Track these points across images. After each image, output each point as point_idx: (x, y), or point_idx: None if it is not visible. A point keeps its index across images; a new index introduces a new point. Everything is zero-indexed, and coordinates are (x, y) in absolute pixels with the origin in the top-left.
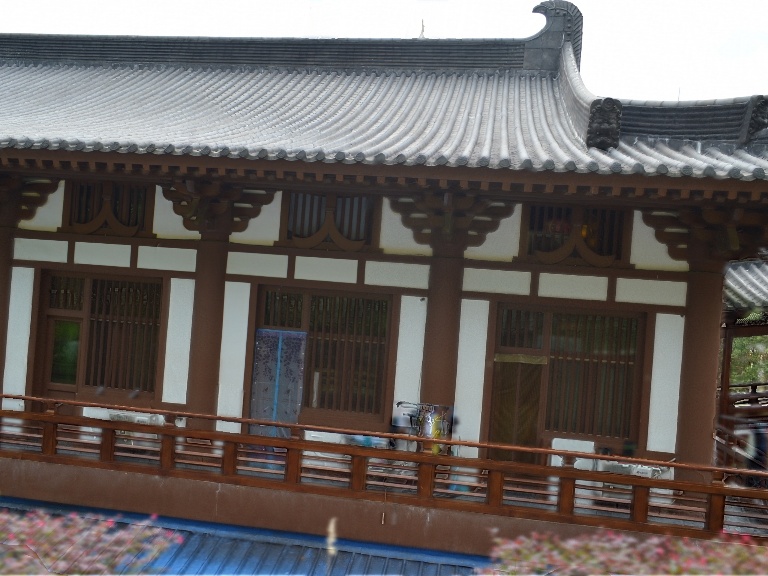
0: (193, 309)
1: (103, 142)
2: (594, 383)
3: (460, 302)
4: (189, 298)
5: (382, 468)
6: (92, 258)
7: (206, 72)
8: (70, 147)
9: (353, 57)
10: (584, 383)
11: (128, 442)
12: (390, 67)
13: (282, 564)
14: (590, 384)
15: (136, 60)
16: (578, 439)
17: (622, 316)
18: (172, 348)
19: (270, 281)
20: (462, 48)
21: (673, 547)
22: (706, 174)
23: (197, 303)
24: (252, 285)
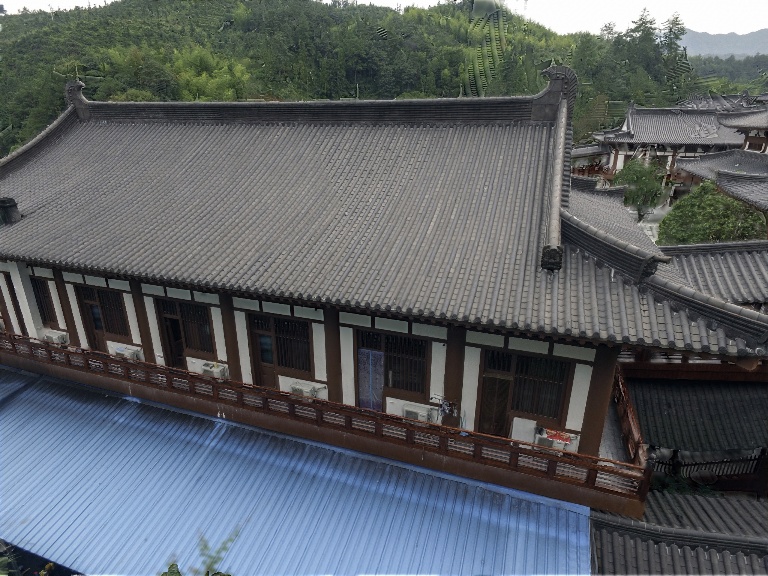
0: (325, 338)
1: (267, 283)
2: (539, 391)
3: (464, 348)
4: (322, 333)
5: (422, 435)
6: (271, 310)
7: (322, 129)
8: (251, 290)
9: (414, 114)
10: (534, 391)
11: (301, 409)
12: (439, 121)
13: (376, 475)
14: (537, 391)
15: (279, 120)
16: (528, 418)
17: (557, 360)
18: (317, 356)
19: (362, 328)
20: (488, 106)
21: (567, 489)
22: (594, 337)
23: (326, 337)
24: (353, 329)
